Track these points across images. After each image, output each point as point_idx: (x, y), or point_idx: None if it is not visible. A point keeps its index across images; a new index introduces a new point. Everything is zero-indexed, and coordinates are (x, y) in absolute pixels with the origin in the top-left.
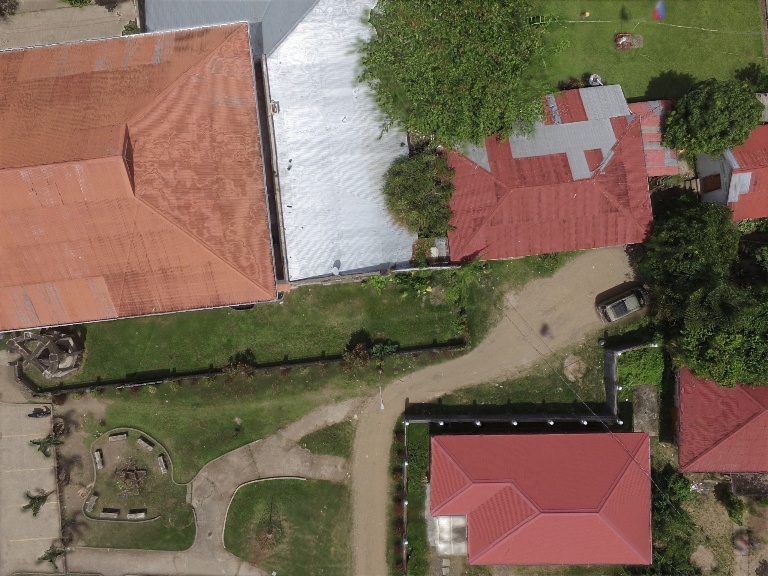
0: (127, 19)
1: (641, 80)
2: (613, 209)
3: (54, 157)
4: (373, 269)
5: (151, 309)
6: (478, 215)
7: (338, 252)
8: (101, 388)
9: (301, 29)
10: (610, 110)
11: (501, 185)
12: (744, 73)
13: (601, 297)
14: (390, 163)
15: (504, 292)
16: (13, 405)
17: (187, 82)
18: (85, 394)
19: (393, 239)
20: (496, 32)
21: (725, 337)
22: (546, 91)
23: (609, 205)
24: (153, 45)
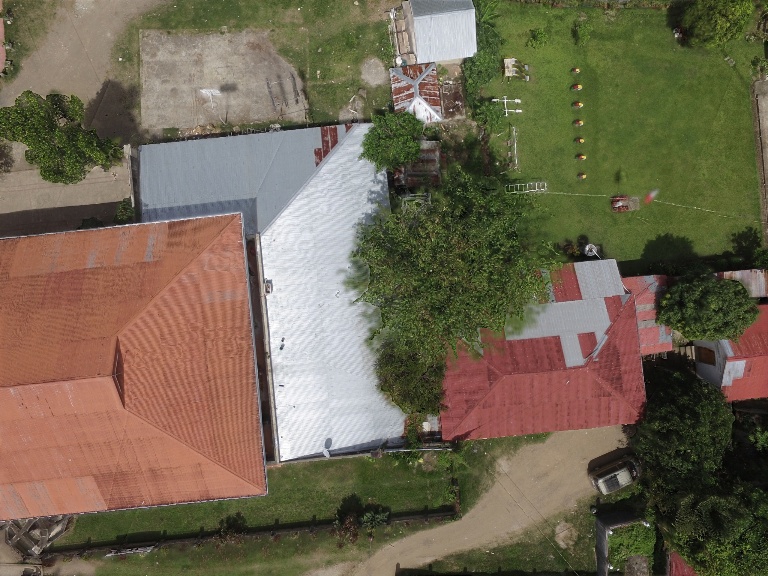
0: (123, 179)
1: (637, 243)
2: (606, 394)
3: (44, 375)
4: (364, 446)
5: (141, 502)
6: (470, 397)
7: (330, 431)
8: (92, 550)
9: (296, 205)
10: (605, 288)
11: (494, 370)
12: (741, 237)
13: (594, 463)
14: (383, 338)
15: (496, 457)
16: (4, 565)
17: (179, 283)
18: (76, 554)
19: (385, 415)
20: (487, 286)
21: (716, 545)
22: (541, 258)
23: (602, 390)
24: (146, 239)
